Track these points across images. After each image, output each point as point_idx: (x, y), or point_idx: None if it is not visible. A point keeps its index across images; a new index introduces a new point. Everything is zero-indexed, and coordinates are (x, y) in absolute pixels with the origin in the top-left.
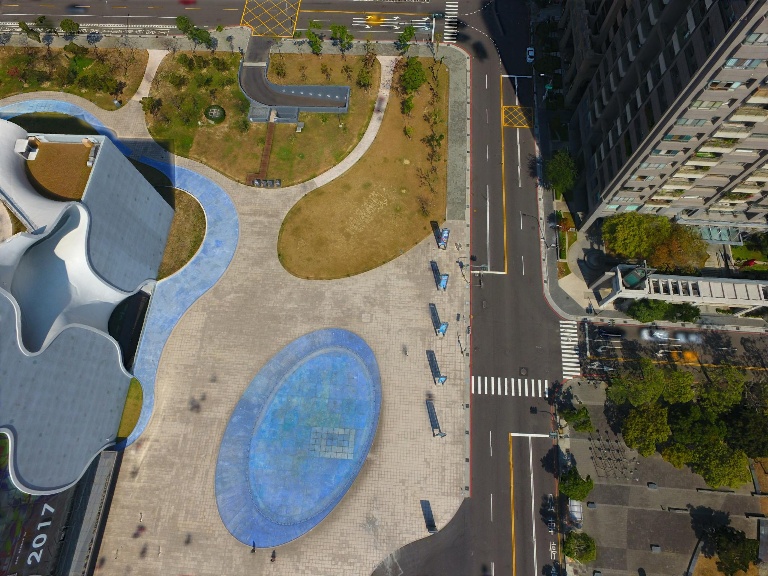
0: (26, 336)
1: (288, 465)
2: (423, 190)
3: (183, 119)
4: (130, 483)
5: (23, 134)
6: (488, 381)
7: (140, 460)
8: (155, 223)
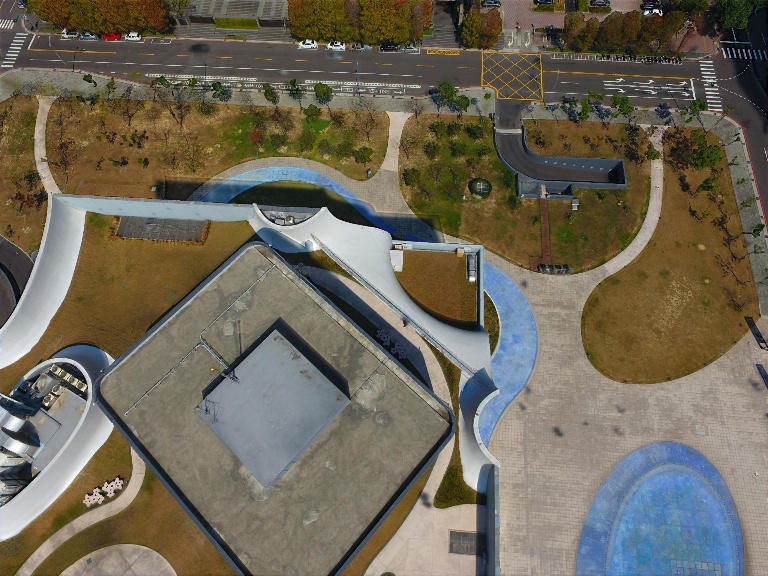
0: None
1: None
2: (728, 280)
3: (450, 194)
4: None
5: (391, 242)
6: None
7: None
8: None
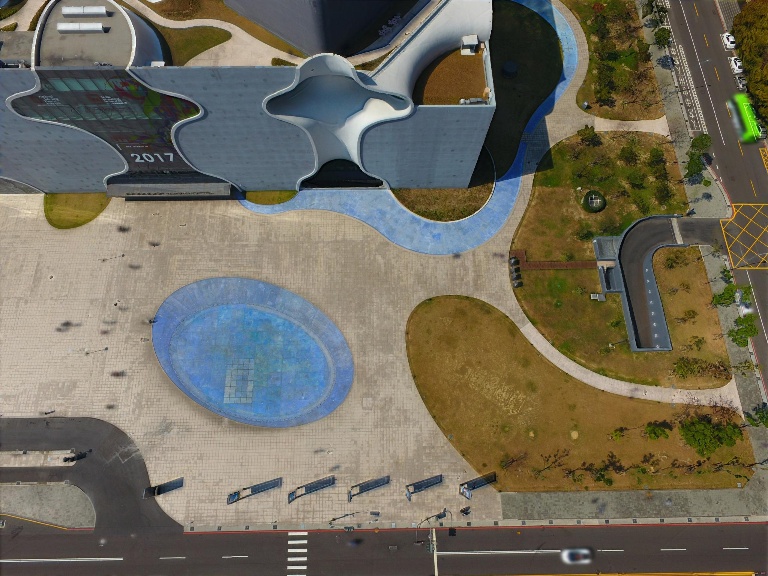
0: (277, 101)
1: (220, 341)
2: (537, 460)
3: (578, 171)
4: (209, 211)
5: (485, 38)
6: (302, 553)
7: (227, 214)
8: (443, 174)
